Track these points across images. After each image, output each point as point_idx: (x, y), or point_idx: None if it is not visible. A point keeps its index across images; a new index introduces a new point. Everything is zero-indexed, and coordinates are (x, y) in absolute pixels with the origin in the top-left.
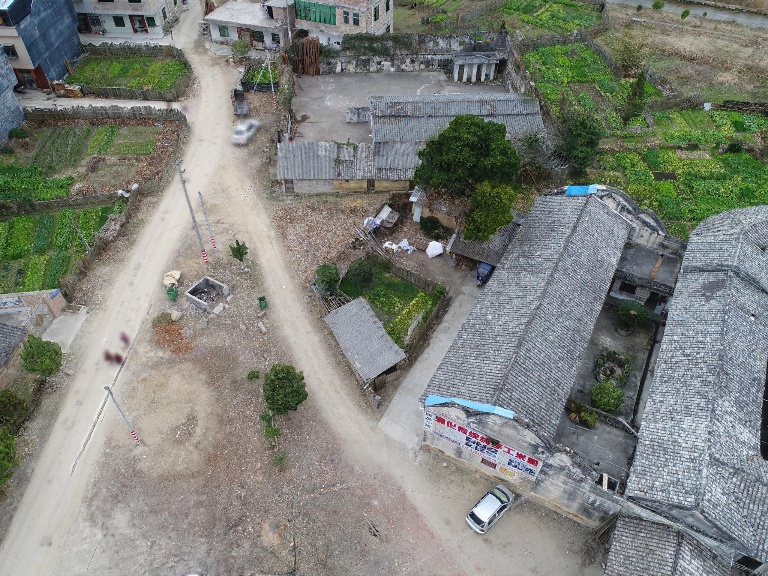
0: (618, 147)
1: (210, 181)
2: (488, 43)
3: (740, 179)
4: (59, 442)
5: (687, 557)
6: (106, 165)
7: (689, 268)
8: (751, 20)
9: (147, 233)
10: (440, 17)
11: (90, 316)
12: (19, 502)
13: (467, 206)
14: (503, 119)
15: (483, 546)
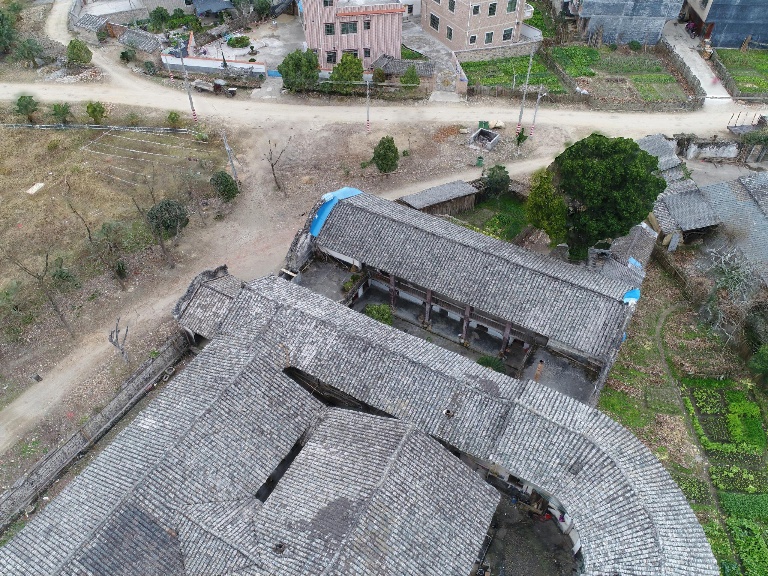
0: None
1: (619, 129)
2: None
3: None
4: (370, 110)
5: None
6: (618, 85)
7: None
8: None
9: (544, 111)
10: None
11: (459, 103)
12: (338, 106)
13: None
14: None
15: (284, 258)
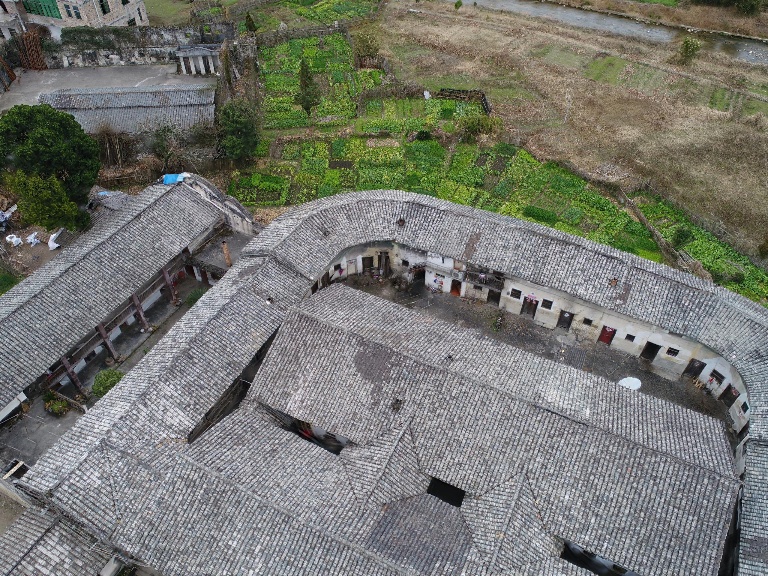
0: (307, 136)
1: None
2: (218, 35)
3: (413, 166)
4: None
5: (51, 543)
6: None
7: (243, 254)
8: (544, 10)
9: None
10: (212, 10)
11: None
12: None
13: (10, 196)
14: (174, 110)
15: None
